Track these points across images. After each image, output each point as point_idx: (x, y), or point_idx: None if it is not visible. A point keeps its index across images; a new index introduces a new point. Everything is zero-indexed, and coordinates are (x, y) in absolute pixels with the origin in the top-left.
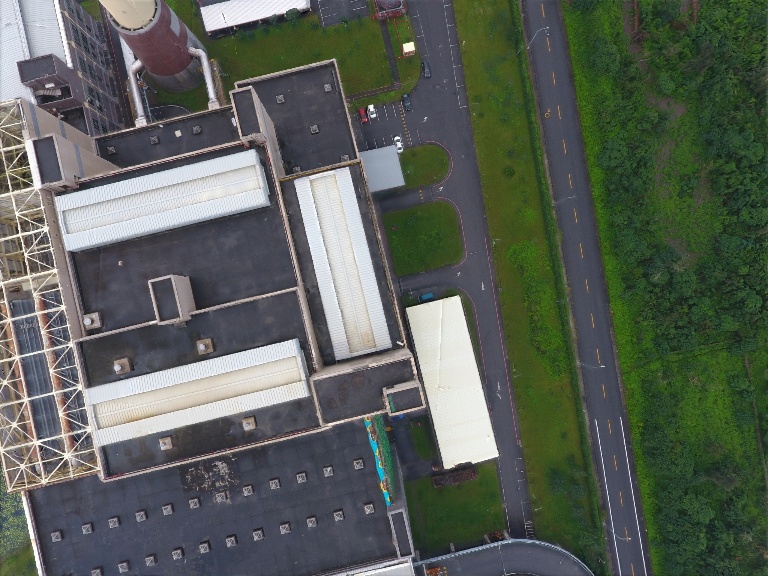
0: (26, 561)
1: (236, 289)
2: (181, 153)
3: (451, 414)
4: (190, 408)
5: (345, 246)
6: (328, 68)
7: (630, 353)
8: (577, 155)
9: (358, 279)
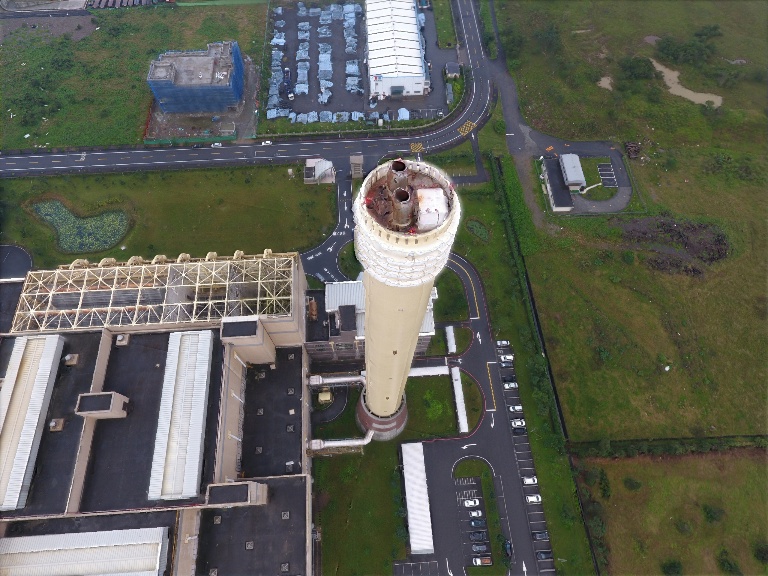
0: (46, 247)
1: (102, 455)
2: (275, 412)
3: None
4: (7, 409)
5: (91, 567)
6: (304, 571)
7: None
8: None
9: (57, 575)
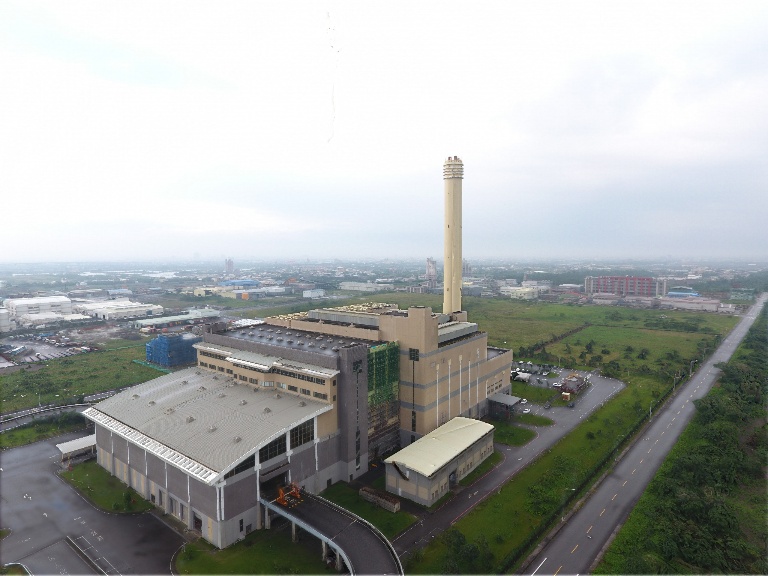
0: None
1: None
2: None
3: (424, 446)
4: None
5: None
6: None
7: (629, 544)
8: (658, 456)
9: None
